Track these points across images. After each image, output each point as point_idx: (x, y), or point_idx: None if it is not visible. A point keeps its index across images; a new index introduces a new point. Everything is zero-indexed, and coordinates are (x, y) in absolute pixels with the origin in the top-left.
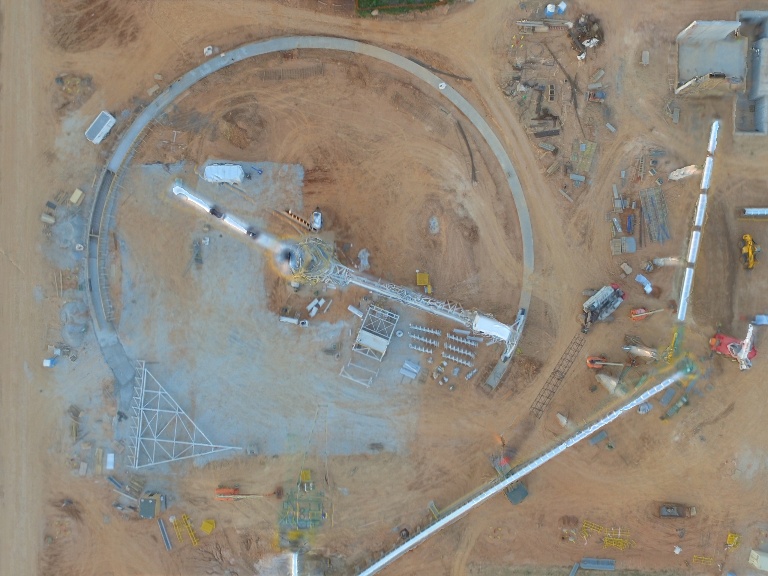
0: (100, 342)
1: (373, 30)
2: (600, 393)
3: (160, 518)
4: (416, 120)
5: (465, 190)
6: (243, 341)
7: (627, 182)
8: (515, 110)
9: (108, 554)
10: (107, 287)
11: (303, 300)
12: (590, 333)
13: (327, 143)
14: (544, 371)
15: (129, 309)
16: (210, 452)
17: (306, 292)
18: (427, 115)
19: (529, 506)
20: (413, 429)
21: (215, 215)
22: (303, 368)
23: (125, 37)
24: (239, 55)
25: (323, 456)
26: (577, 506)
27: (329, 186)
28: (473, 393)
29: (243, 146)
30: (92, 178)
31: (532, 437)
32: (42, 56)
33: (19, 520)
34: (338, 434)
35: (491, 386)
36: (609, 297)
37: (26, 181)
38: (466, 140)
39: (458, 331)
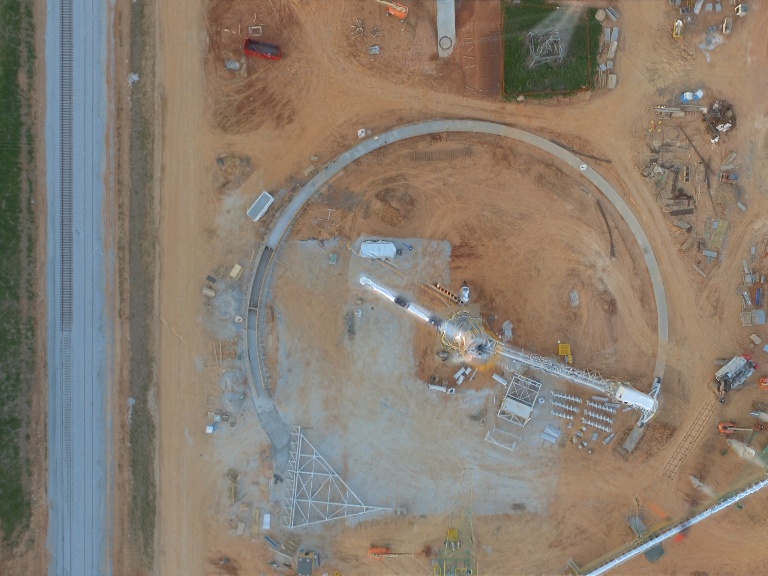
0: (257, 409)
1: (518, 114)
2: (730, 456)
3: (314, 575)
4: (558, 199)
5: (604, 265)
6: (393, 408)
7: (756, 258)
8: (652, 190)
9: None
10: (264, 357)
11: (450, 369)
12: None
13: (474, 221)
14: (677, 435)
15: (285, 377)
16: (362, 513)
17: (453, 361)
18: (569, 195)
19: (662, 562)
20: (553, 490)
21: None
22: (450, 433)
23: (282, 120)
24: (391, 138)
25: (468, 516)
26: (707, 562)
27: (475, 261)
28: (610, 456)
29: (394, 224)
30: (250, 254)
31: (665, 497)
32: (203, 138)
33: None
34: (482, 495)
35: (626, 449)
36: (742, 367)
37: (188, 256)
38: (605, 218)
39: (597, 398)
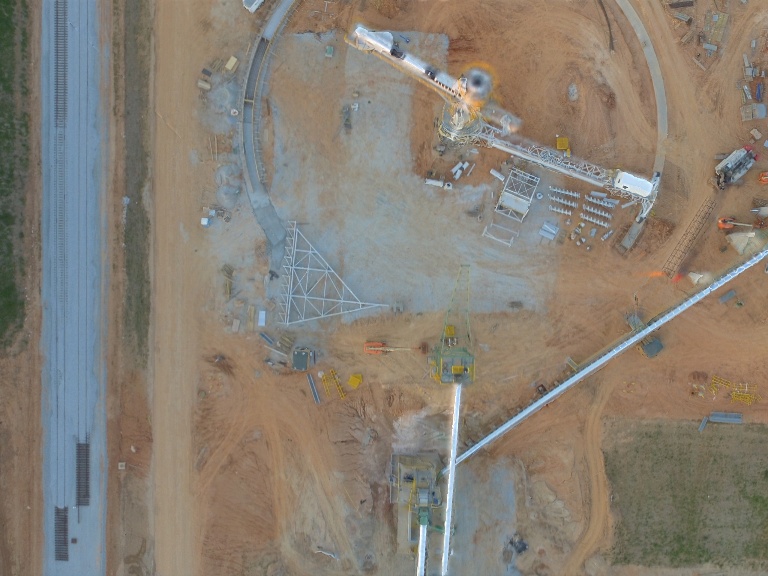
0: (253, 204)
1: None
2: (730, 253)
3: (309, 373)
4: None
5: (603, 58)
6: (390, 203)
7: (757, 51)
8: None
9: (259, 408)
10: (260, 151)
11: (447, 164)
12: (721, 195)
13: (471, 13)
14: (676, 233)
15: (281, 172)
16: (358, 309)
17: (450, 156)
18: None
19: (661, 362)
20: (551, 288)
21: (395, 55)
22: (447, 229)
23: None
24: None
25: (465, 314)
26: (706, 362)
27: (473, 55)
28: (608, 254)
29: (391, 16)
30: (246, 46)
31: (664, 296)
32: None
33: (174, 375)
34: (479, 293)
35: (625, 247)
36: (742, 159)
37: (183, 49)
38: (604, 11)
39: (595, 194)
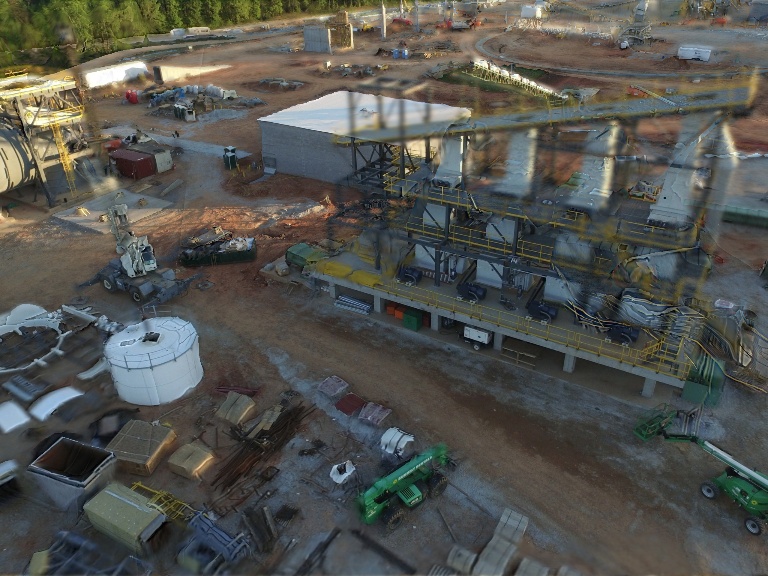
0: None
1: None
2: None
3: None
4: None
5: None
6: None
7: None
8: None
9: None
10: None
11: None
12: None
13: None
14: None
15: None
16: None
17: None
18: None
19: None
20: None
21: None
22: None
23: None
24: None
25: None
26: None
27: None
28: None
29: None
30: None
31: None
32: None
33: None
34: None
35: None
36: None
37: None
38: None
39: None
